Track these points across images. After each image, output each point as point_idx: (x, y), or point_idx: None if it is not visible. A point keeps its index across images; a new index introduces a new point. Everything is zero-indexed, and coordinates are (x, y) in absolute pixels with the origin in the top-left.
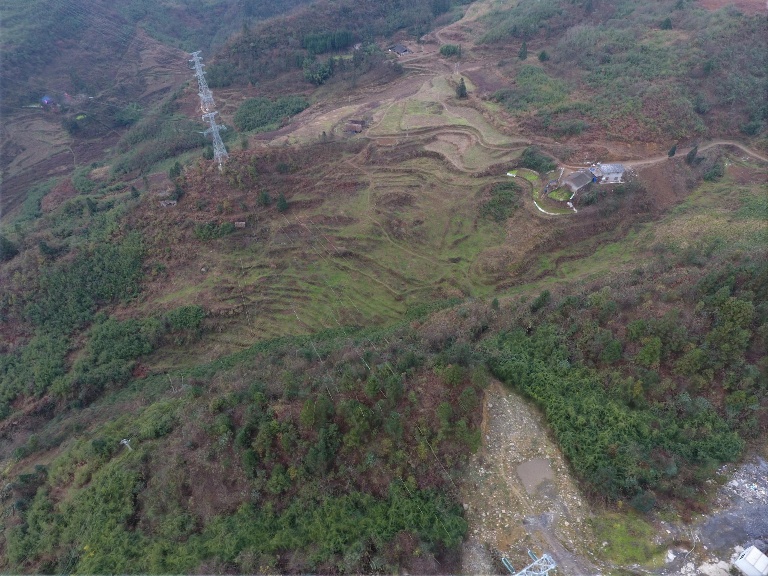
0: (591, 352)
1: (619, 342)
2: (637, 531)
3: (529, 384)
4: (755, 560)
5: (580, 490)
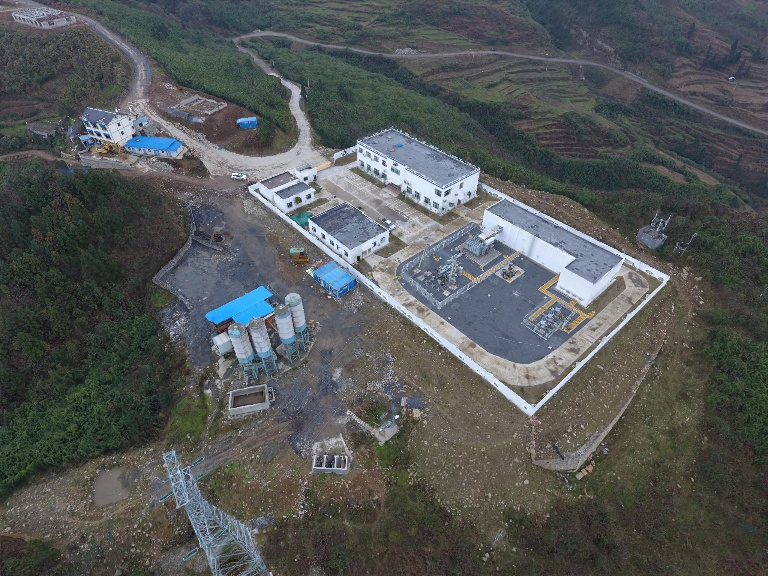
0: (0, 400)
1: (3, 368)
2: (185, 409)
3: (4, 477)
4: (221, 341)
5: (140, 447)
